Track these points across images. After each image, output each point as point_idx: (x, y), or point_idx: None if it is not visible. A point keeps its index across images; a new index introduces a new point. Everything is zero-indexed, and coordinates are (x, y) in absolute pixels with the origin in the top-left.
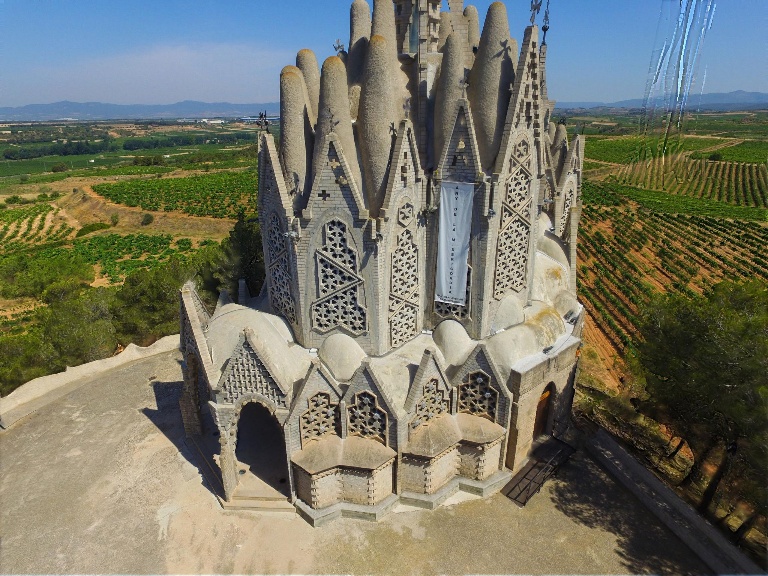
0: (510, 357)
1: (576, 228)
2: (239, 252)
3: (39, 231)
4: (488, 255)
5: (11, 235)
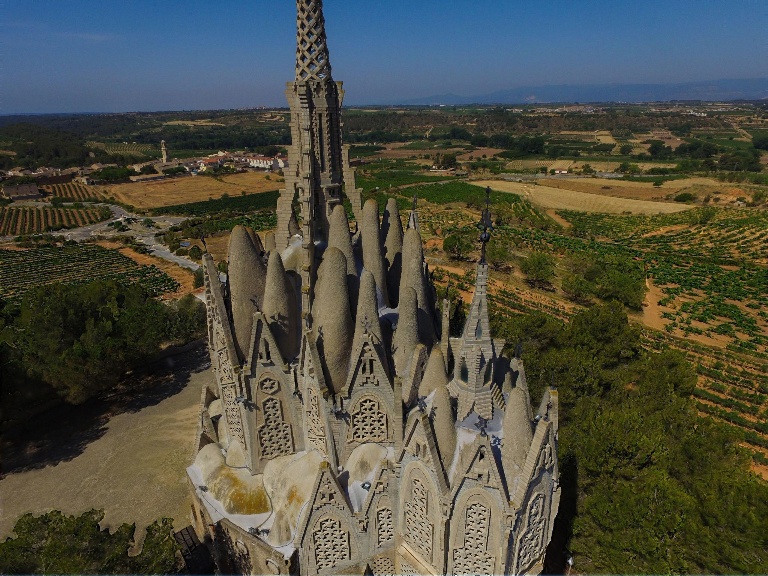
0: (196, 458)
1: (315, 484)
2: None
3: (761, 243)
4: (220, 393)
5: (734, 239)
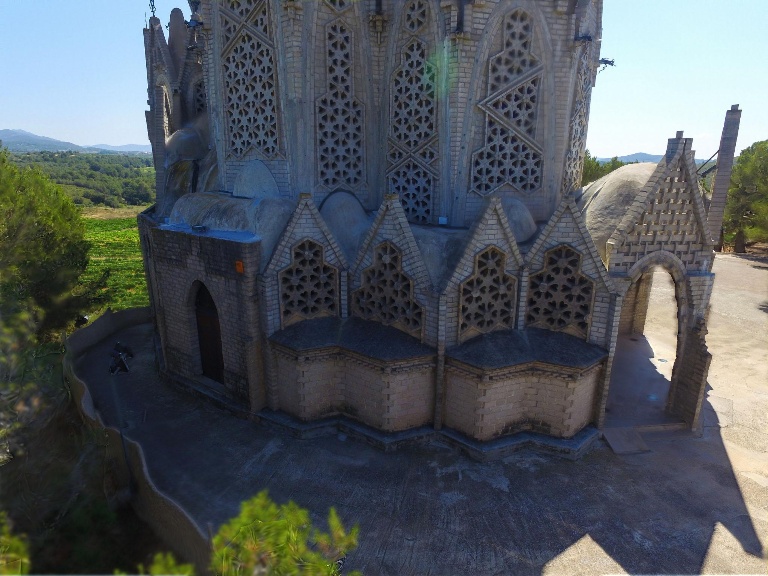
0: None
1: None
2: None
3: None
4: None
5: None
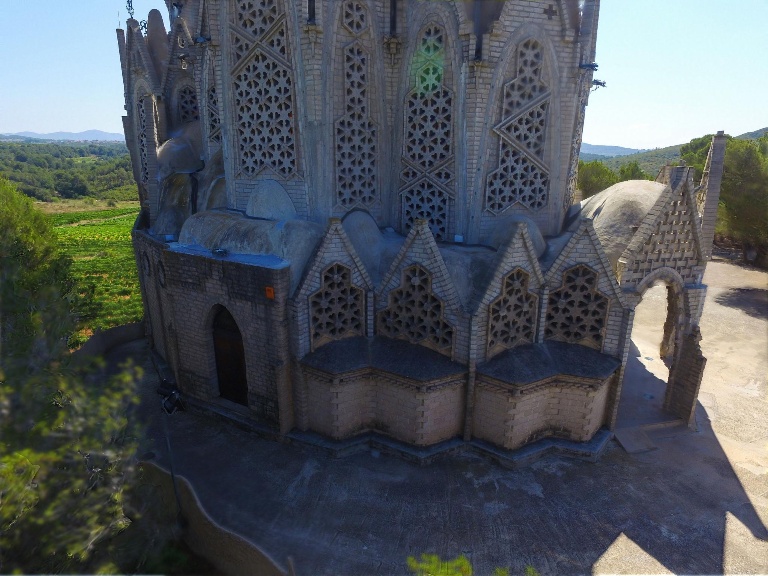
0: None
1: None
2: (70, 372)
3: None
4: None
5: None
